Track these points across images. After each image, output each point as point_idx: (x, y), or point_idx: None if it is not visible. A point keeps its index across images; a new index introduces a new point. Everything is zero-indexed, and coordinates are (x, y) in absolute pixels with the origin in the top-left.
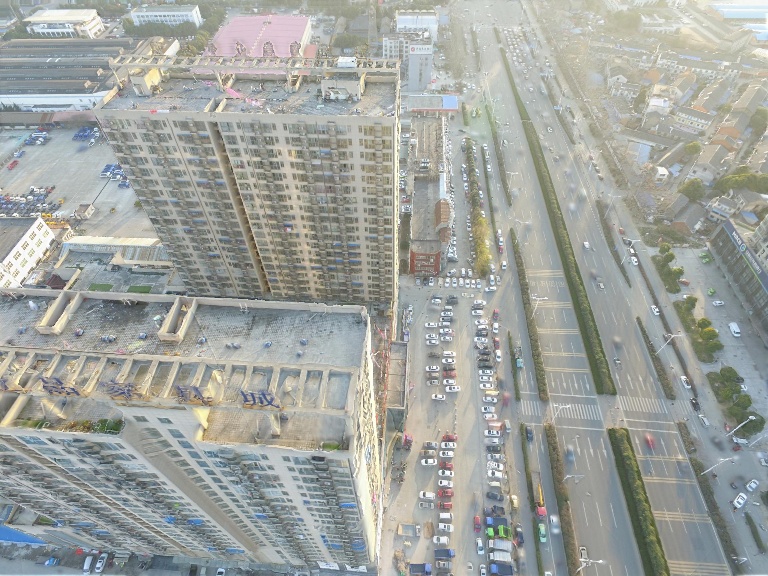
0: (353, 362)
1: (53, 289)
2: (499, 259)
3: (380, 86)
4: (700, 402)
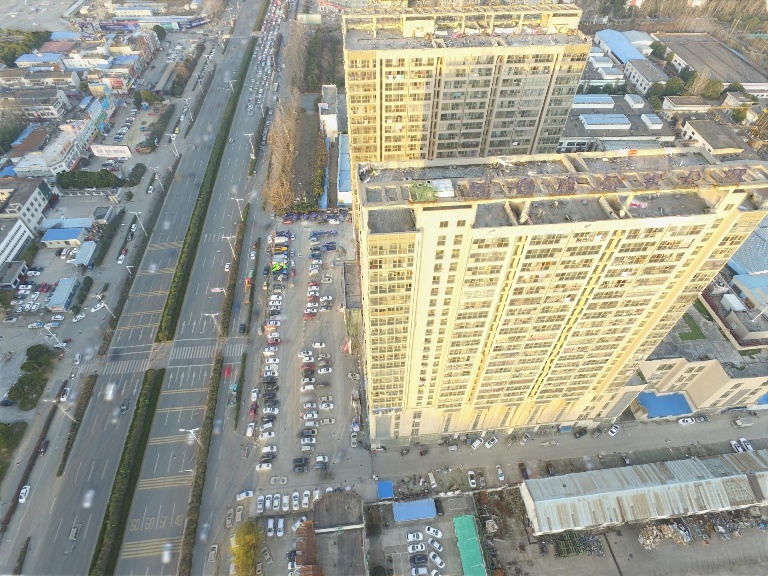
0: (349, 44)
1: (513, 46)
2: (218, 569)
3: (393, 230)
4: (67, 376)
